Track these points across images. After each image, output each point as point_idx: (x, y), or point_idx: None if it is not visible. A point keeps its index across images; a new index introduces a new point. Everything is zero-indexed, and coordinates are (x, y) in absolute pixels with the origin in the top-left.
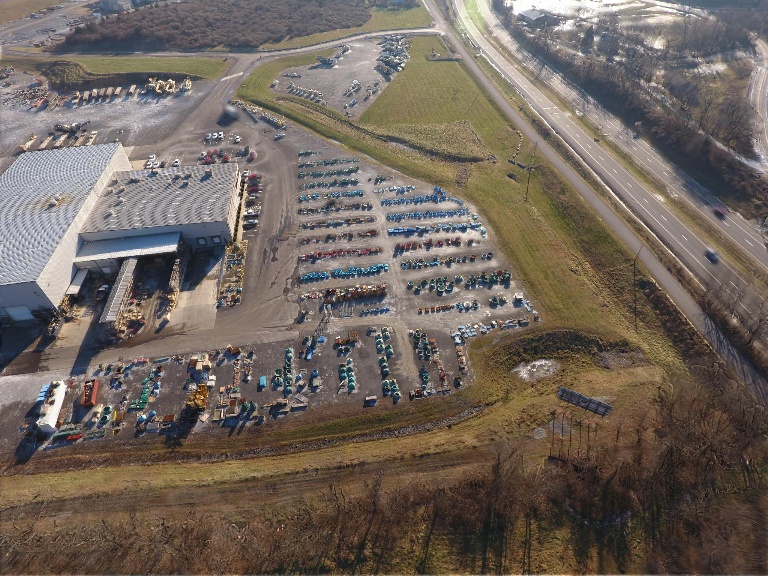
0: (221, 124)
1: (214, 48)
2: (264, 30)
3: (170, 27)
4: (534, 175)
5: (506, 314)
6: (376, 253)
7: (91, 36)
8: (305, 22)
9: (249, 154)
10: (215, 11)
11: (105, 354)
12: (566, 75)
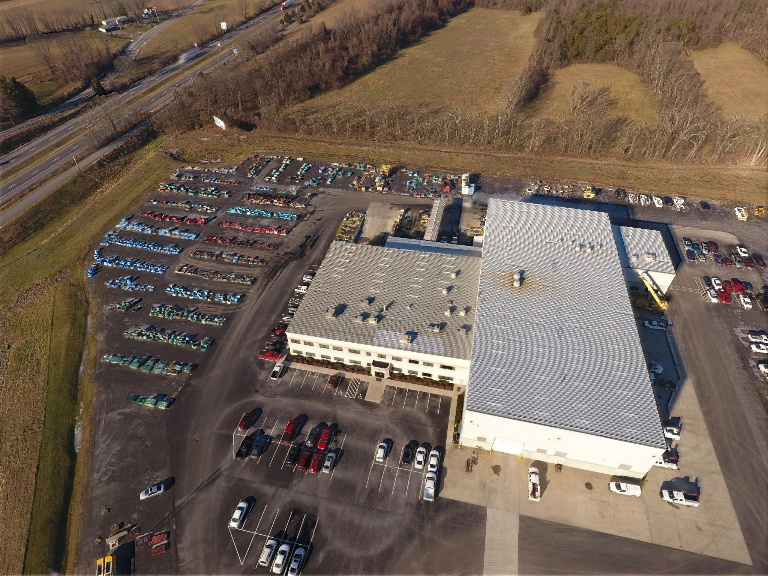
0: None
1: None
2: None
3: None
4: None
5: (194, 172)
6: (226, 222)
7: None
8: None
9: None
10: None
11: None
12: None
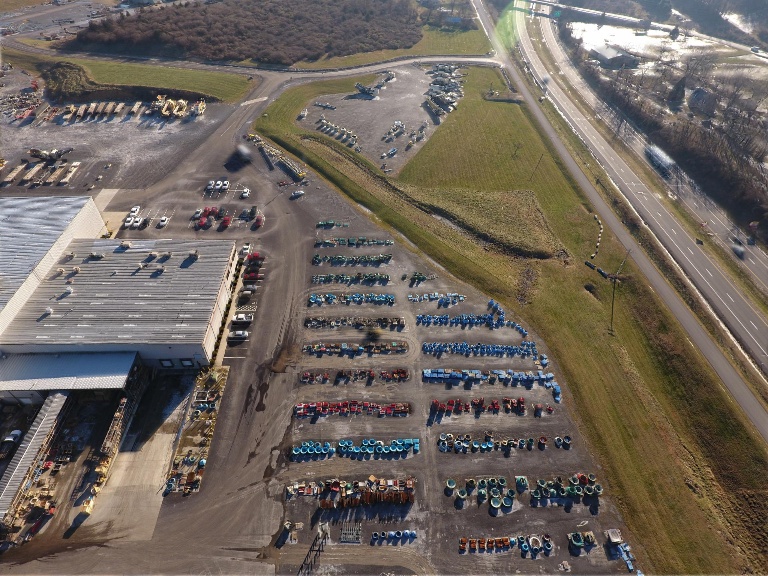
0: (229, 167)
1: (240, 62)
2: (300, 44)
3: (194, 32)
4: (620, 290)
5: (595, 572)
6: (404, 414)
7: (105, 35)
8: (347, 38)
9: (255, 218)
10: (249, 17)
11: None
12: (652, 138)
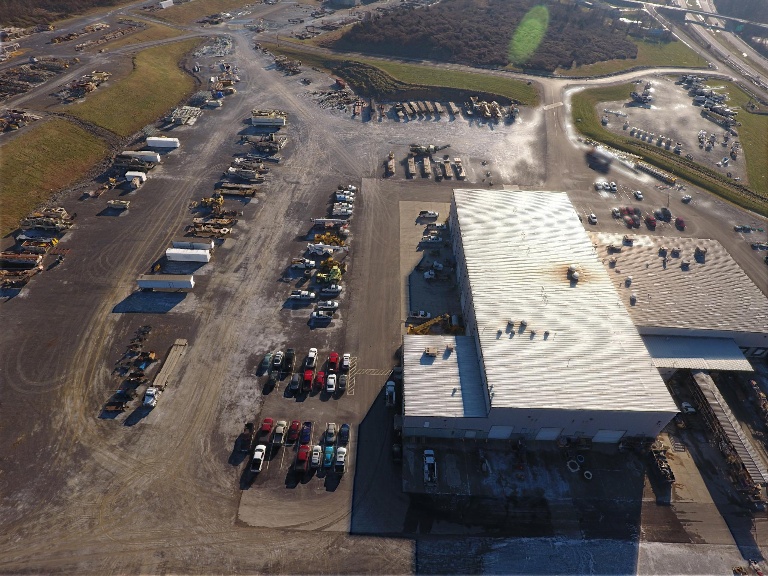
0: (597, 169)
1: (506, 67)
2: (546, 51)
3: (454, 37)
4: None
5: None
6: None
7: (373, 36)
8: (580, 47)
9: (671, 219)
10: (481, 22)
11: (764, 528)
12: None
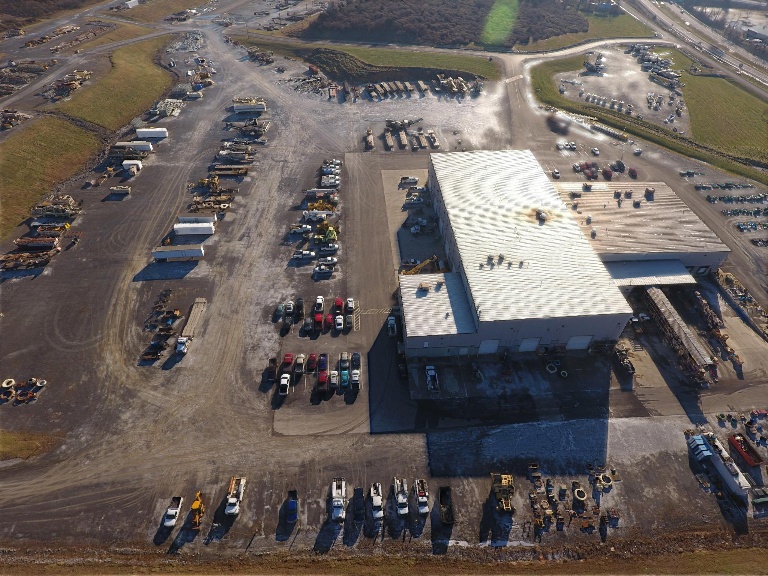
0: (557, 132)
1: (467, 45)
2: (504, 29)
3: (416, 20)
4: None
5: None
6: None
7: (339, 24)
8: (536, 23)
9: (625, 169)
10: (441, 5)
11: (708, 400)
12: None
